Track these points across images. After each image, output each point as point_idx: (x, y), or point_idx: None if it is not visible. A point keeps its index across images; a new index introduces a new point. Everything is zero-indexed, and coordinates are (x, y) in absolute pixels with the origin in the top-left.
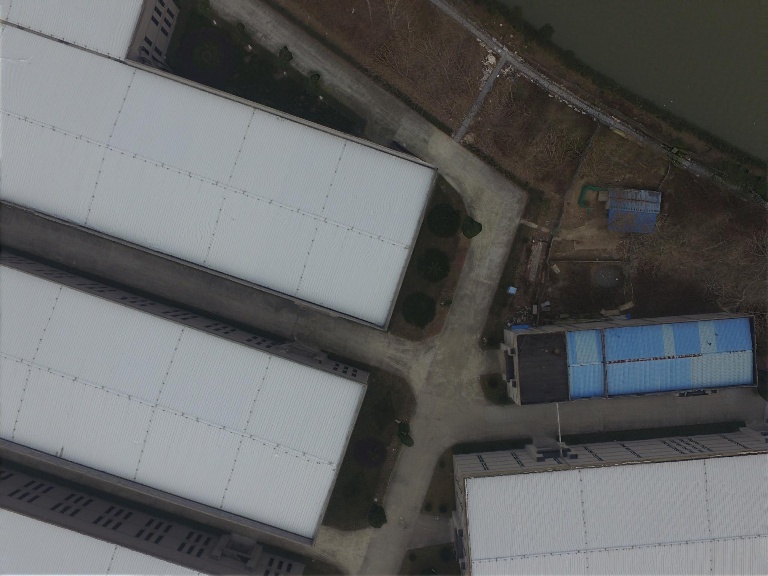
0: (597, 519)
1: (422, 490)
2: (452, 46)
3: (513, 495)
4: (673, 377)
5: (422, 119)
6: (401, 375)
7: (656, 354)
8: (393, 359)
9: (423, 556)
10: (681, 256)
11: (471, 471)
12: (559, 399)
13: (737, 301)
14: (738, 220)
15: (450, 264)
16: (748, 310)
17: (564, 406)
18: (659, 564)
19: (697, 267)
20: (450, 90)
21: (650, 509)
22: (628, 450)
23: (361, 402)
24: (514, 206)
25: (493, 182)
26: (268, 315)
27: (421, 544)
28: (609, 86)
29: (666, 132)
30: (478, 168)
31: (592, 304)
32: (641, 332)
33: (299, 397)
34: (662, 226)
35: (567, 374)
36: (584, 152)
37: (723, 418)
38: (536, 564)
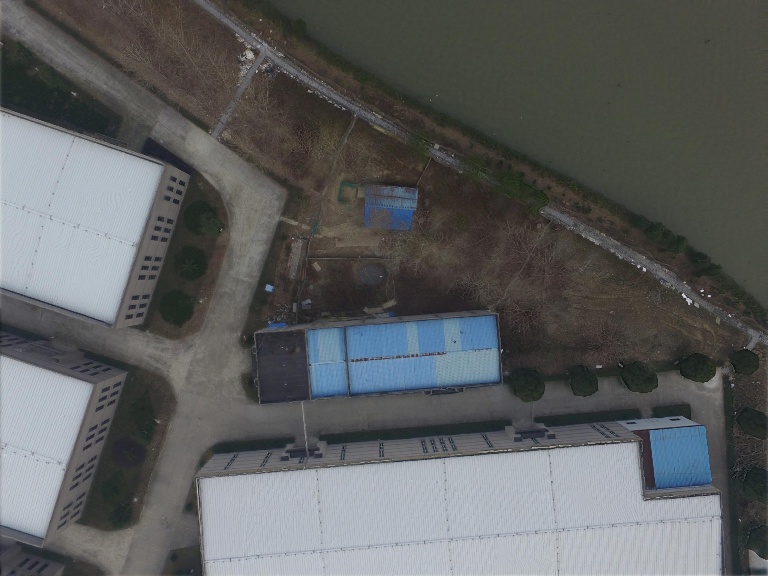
0: (333, 519)
1: (184, 490)
2: (206, 41)
3: (253, 495)
4: (418, 375)
5: (179, 115)
6: (160, 374)
7: (399, 352)
8: (152, 358)
9: (185, 556)
10: (441, 253)
11: (208, 471)
12: (301, 398)
13: (499, 298)
14: (499, 217)
15: (208, 262)
16: (513, 308)
17: (327, 405)
18: (402, 564)
19: (457, 264)
20: (205, 86)
21: (388, 509)
22: (379, 449)
23: (88, 401)
24: (274, 203)
25: (252, 179)
26: (25, 314)
27: (184, 544)
28: (369, 81)
29: (429, 128)
30: (237, 165)
31: (349, 302)
32: (385, 330)
33: (29, 396)
34: (424, 223)
35: (307, 373)
36: (340, 148)
37: (490, 417)
38: (271, 564)
